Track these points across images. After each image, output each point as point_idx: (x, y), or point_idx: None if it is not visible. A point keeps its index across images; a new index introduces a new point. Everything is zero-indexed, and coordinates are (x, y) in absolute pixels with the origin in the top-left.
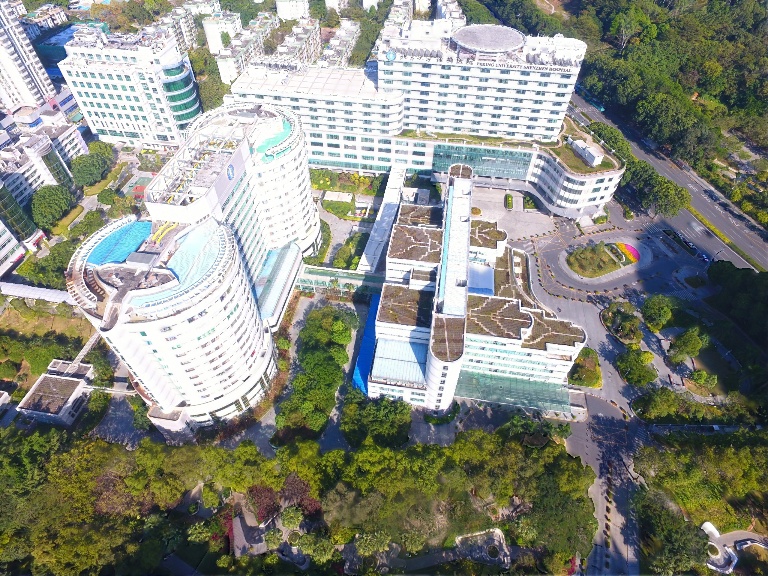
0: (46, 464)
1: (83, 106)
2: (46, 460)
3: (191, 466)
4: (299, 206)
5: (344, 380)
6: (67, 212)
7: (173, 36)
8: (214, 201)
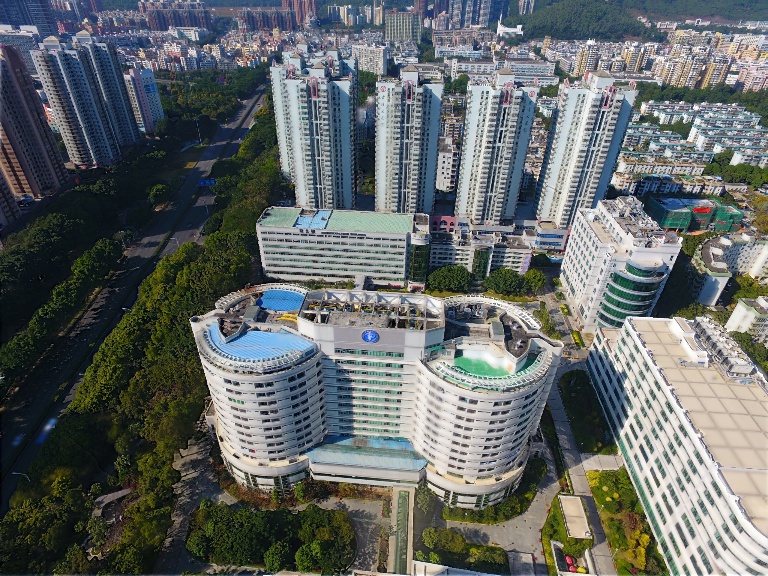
0: (191, 355)
1: (569, 246)
2: (197, 354)
3: (159, 435)
4: (448, 442)
5: (258, 575)
6: (458, 291)
7: (679, 246)
8: (327, 336)
